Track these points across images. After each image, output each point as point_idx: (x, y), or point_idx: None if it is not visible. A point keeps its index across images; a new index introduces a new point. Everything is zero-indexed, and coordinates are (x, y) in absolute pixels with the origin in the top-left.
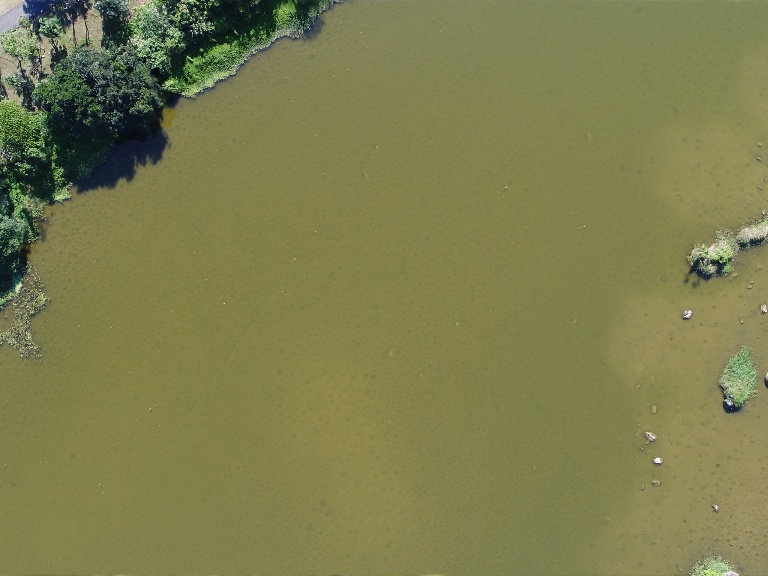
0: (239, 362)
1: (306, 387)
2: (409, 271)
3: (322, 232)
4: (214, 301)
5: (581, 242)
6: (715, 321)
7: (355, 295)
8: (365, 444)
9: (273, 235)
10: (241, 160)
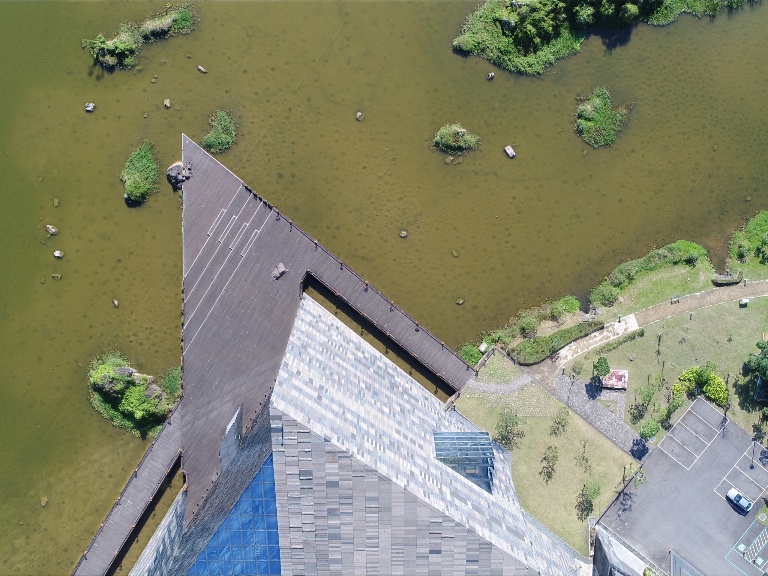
0: None
1: None
2: None
3: None
4: None
5: None
6: (118, 115)
7: None
8: None
9: None
10: None
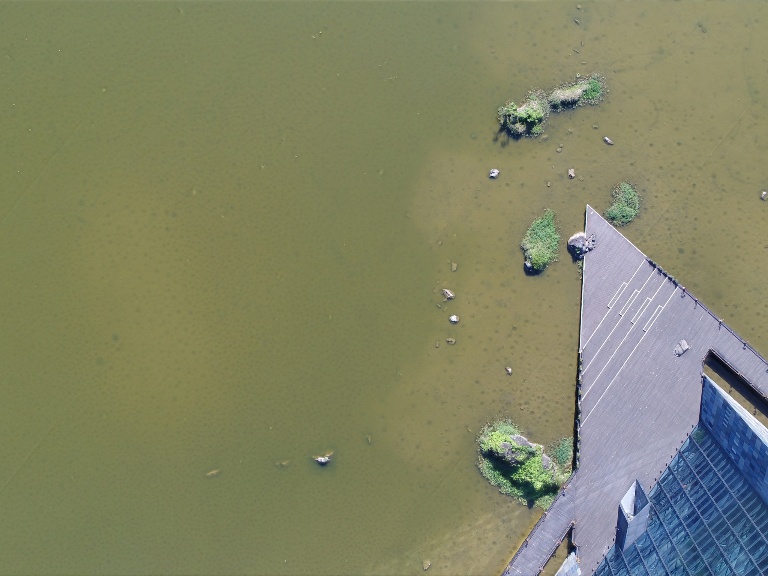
0: (41, 190)
1: (107, 220)
2: (218, 110)
3: (133, 65)
4: (20, 127)
5: (392, 93)
6: (522, 182)
7: (162, 131)
8: (162, 281)
9: (84, 64)
10: None
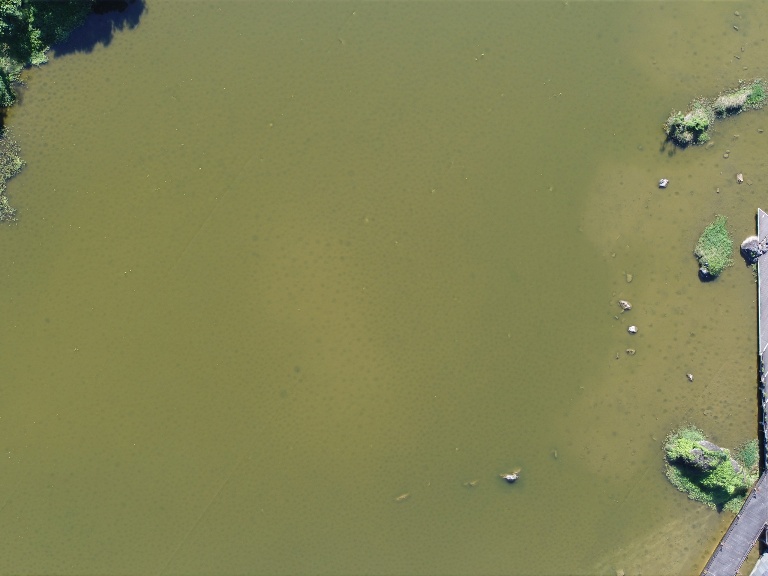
0: (215, 228)
1: (281, 253)
2: (385, 138)
3: (299, 98)
4: (190, 166)
5: (557, 110)
6: (691, 190)
7: (331, 161)
8: (340, 311)
9: (250, 101)
10: (218, 26)
